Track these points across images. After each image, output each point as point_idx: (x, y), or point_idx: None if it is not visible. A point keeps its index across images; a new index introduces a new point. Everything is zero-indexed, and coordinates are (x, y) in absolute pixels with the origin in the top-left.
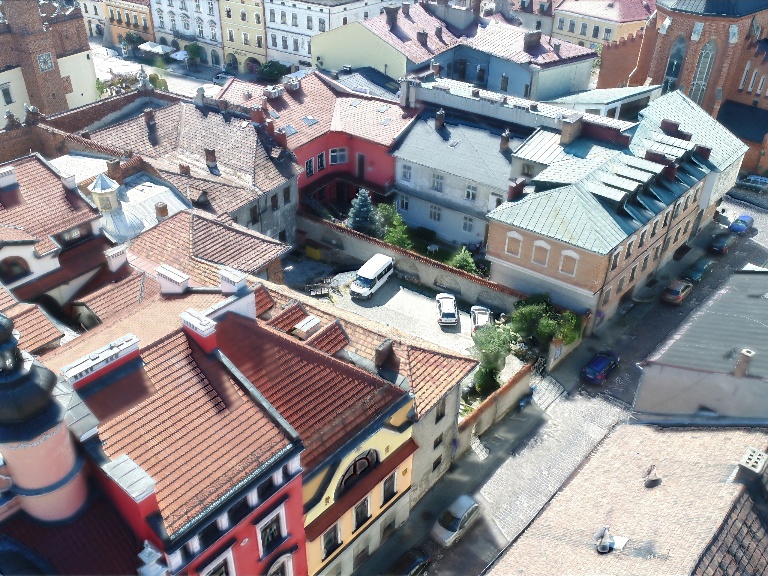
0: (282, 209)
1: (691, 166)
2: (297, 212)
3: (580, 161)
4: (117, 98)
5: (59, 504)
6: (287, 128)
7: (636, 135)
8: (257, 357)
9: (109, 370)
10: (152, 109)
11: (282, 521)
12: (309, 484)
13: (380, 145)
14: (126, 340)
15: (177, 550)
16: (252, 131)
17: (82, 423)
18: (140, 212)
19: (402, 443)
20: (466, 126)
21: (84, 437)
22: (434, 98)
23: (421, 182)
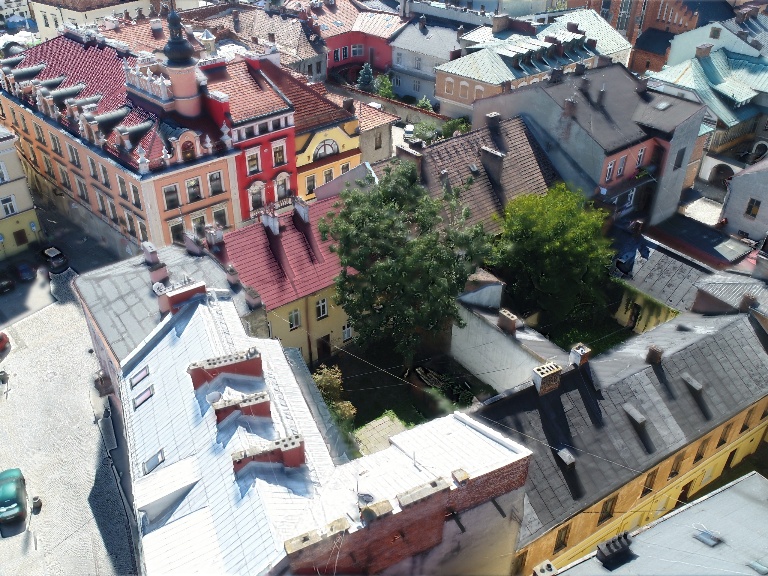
0: (315, 76)
1: (582, 52)
2: (326, 81)
3: (501, 41)
4: (216, 6)
5: (191, 108)
6: (322, 26)
7: (545, 30)
8: (279, 81)
9: (212, 67)
10: (237, 10)
11: (285, 152)
12: (299, 139)
13: (382, 38)
14: (220, 56)
15: (237, 130)
16: (299, 25)
17: (201, 78)
18: (227, 56)
19: (353, 148)
20: (439, 27)
21: (202, 84)
22: (421, 10)
23: (408, 64)
